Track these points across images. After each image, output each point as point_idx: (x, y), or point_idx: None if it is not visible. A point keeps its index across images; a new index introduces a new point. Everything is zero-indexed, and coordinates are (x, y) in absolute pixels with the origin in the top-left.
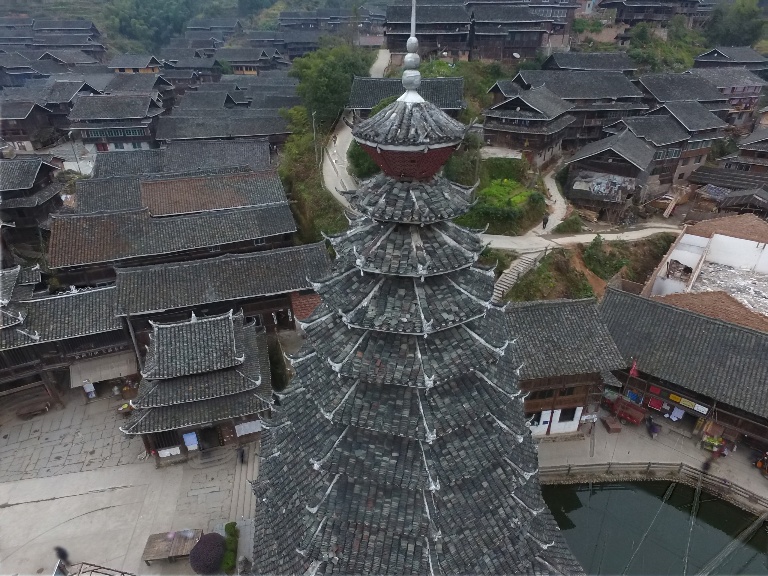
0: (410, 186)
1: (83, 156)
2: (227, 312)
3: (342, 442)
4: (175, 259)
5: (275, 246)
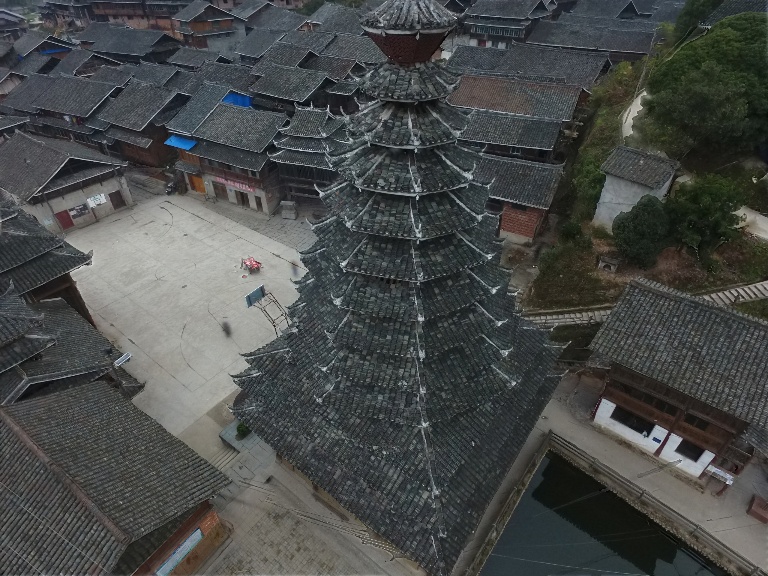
0: None
1: None
2: None
3: (321, 253)
4: None
5: (527, 159)
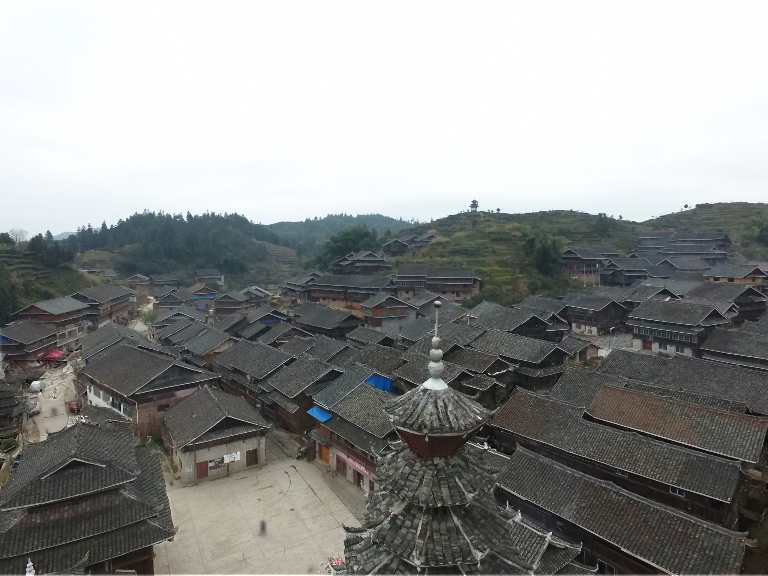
0: None
1: None
2: (547, 532)
3: None
4: (580, 463)
5: (695, 507)
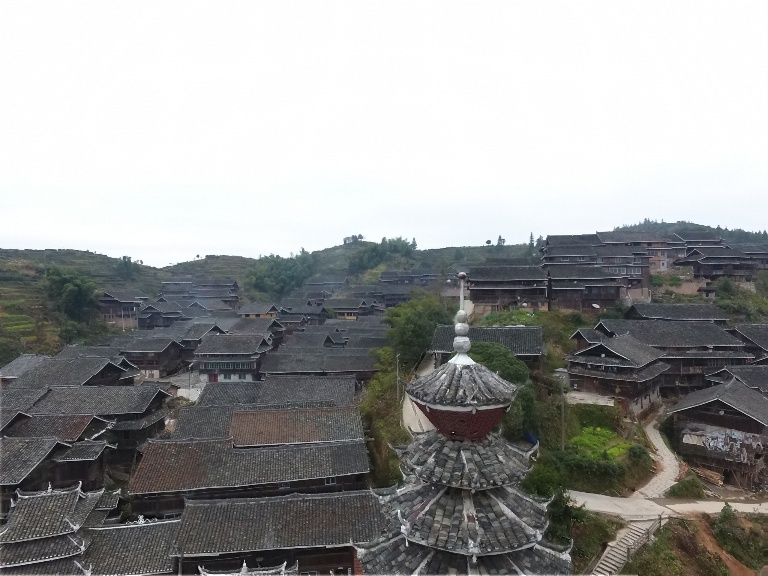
0: (461, 446)
1: (196, 384)
2: (280, 565)
3: None
4: (245, 494)
5: (345, 487)
